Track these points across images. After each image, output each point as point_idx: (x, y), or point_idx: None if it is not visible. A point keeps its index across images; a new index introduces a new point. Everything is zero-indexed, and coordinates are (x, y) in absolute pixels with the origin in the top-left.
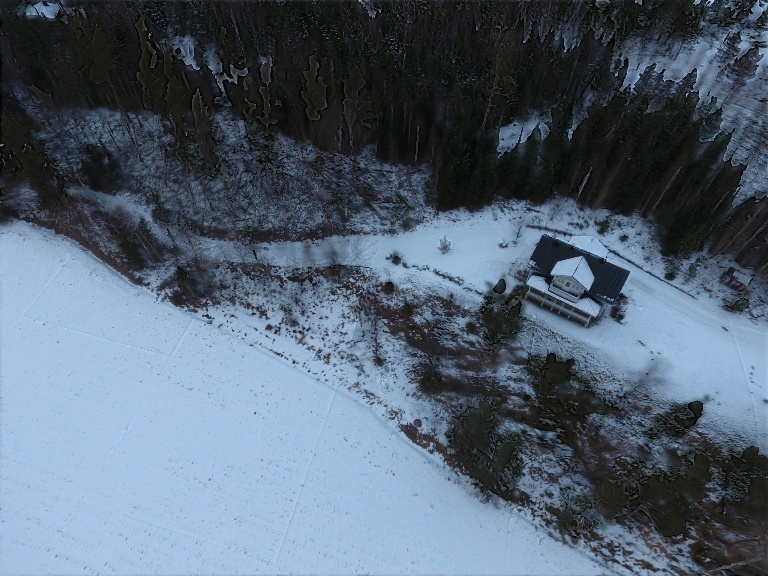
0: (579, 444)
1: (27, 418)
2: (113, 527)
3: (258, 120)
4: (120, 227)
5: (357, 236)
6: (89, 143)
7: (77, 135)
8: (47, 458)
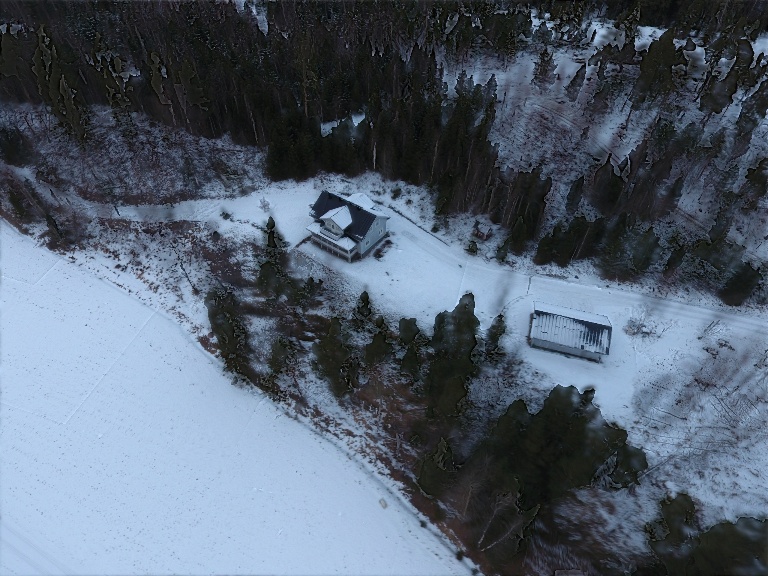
0: None
1: None
2: None
3: (146, 111)
4: None
5: (205, 200)
6: (12, 129)
7: (4, 122)
8: None
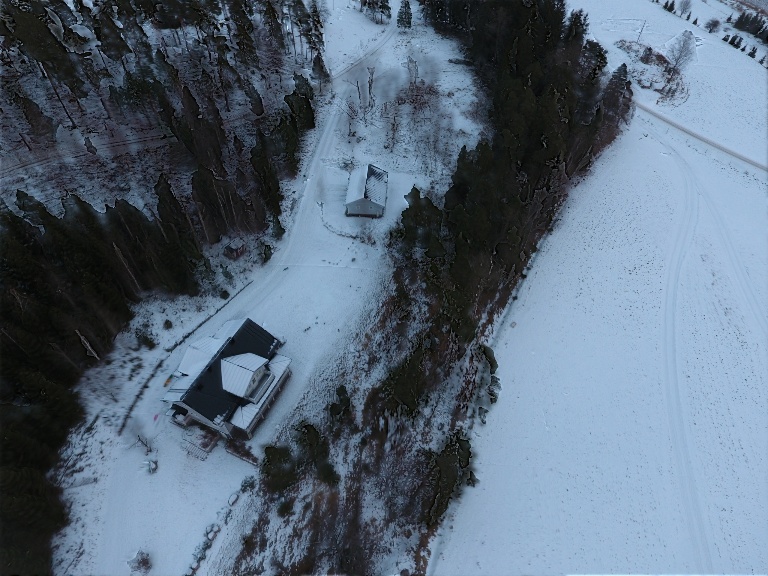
0: None
1: None
2: None
3: None
4: None
5: None
6: None
7: None
8: None
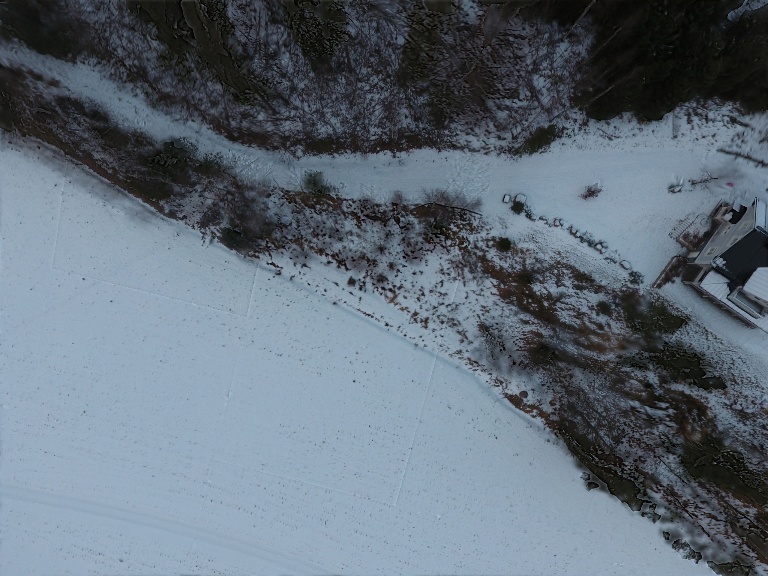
0: (688, 429)
1: (124, 387)
2: (250, 480)
3: None
4: (110, 127)
5: (459, 153)
6: None
7: None
8: (164, 424)
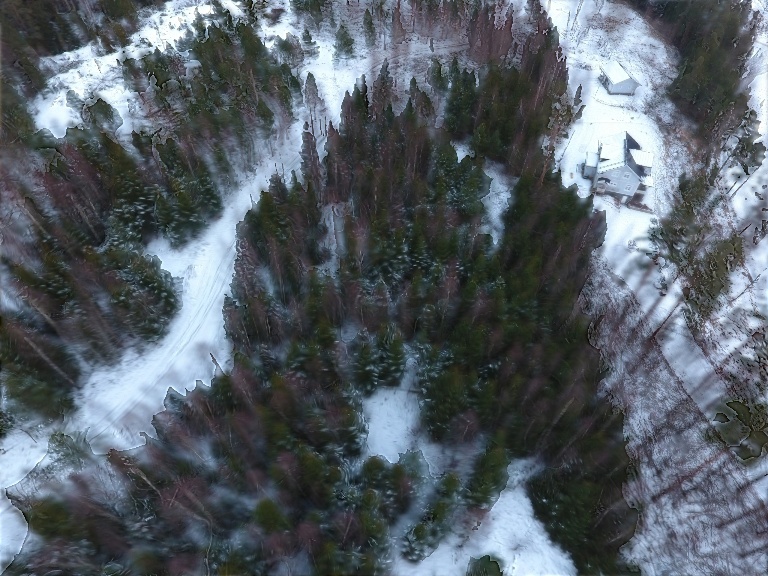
0: None
1: None
2: None
3: None
4: None
5: None
6: None
7: None
8: None
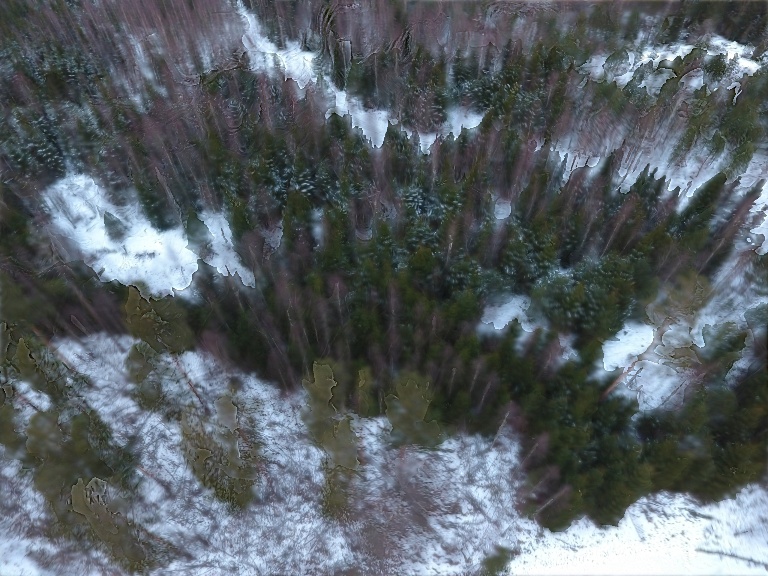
0: None
1: None
2: None
3: (215, 355)
4: None
5: None
6: None
7: None
8: None
